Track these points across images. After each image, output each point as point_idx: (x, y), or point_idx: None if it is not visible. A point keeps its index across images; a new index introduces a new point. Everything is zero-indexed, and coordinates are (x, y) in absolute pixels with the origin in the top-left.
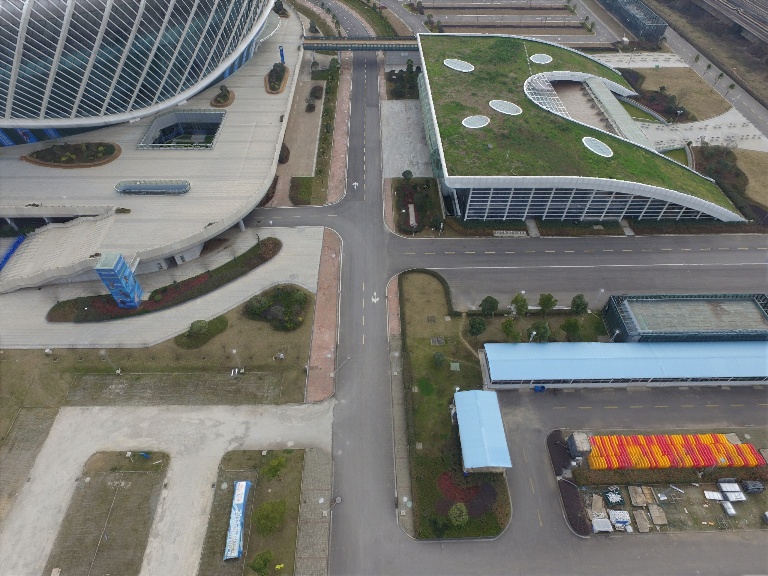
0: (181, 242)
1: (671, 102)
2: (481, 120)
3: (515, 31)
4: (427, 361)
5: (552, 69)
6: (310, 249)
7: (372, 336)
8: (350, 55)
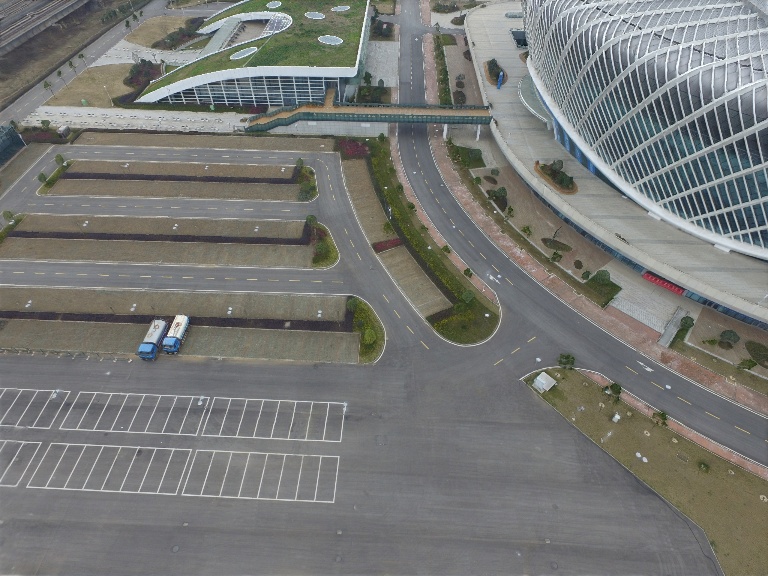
0: (493, 3)
1: (138, 70)
2: (337, 9)
3: (183, 169)
4: (387, 1)
5: (244, 47)
6: (437, 21)
7: (407, 5)
8: (432, 141)
